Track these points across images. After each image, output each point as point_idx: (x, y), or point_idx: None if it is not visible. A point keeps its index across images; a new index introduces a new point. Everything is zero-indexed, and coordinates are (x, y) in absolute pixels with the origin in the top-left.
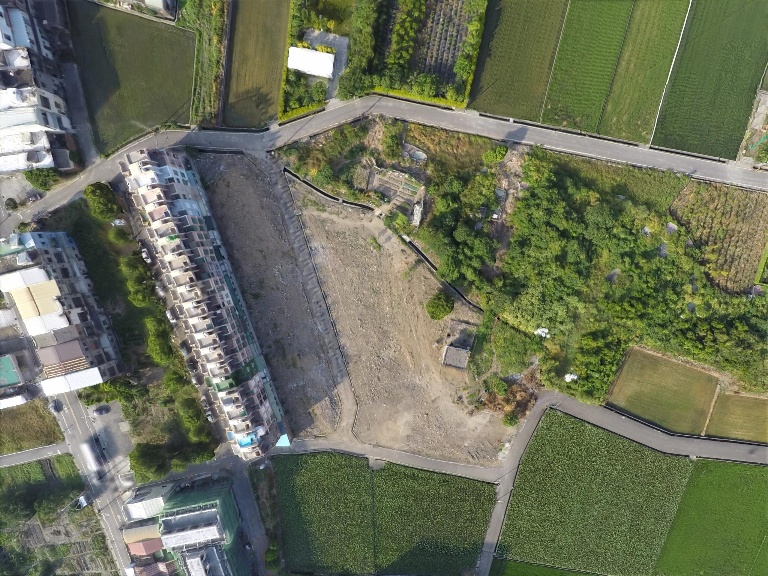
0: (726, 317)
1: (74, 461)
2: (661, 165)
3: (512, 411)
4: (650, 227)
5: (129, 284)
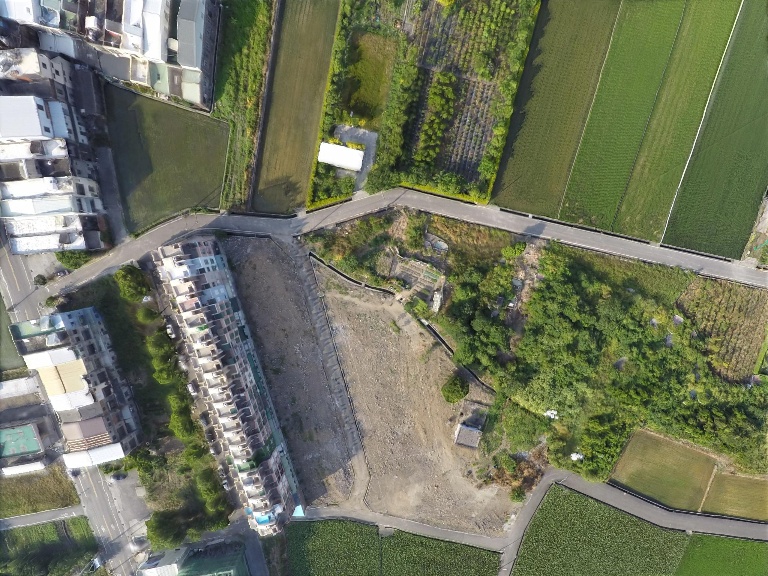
0: (726, 404)
1: (89, 523)
2: (670, 262)
3: (519, 486)
4: (658, 319)
5: (155, 363)
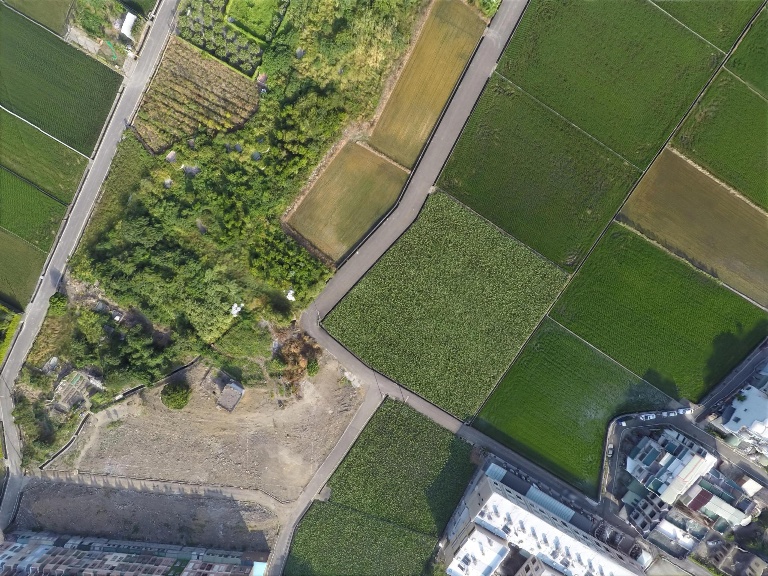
0: (278, 121)
1: None
2: (111, 152)
3: (307, 361)
4: (165, 178)
5: None
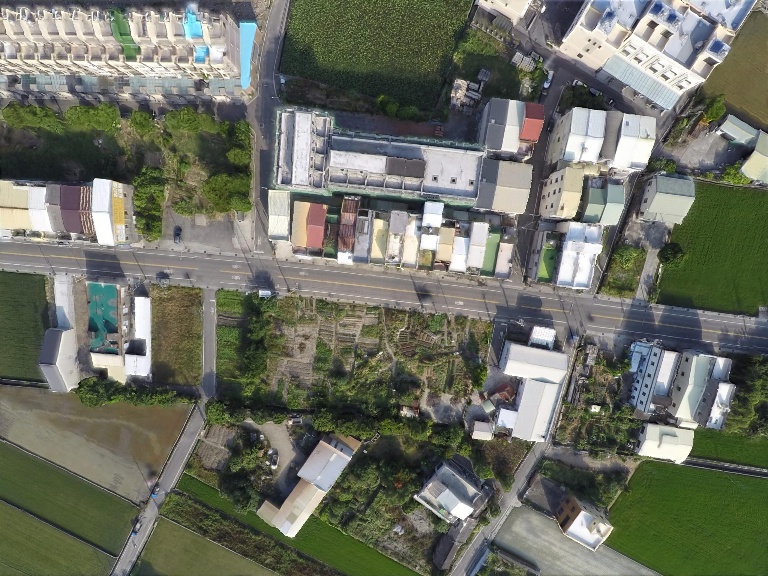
0: None
1: (226, 290)
2: None
3: None
4: None
5: (23, 115)
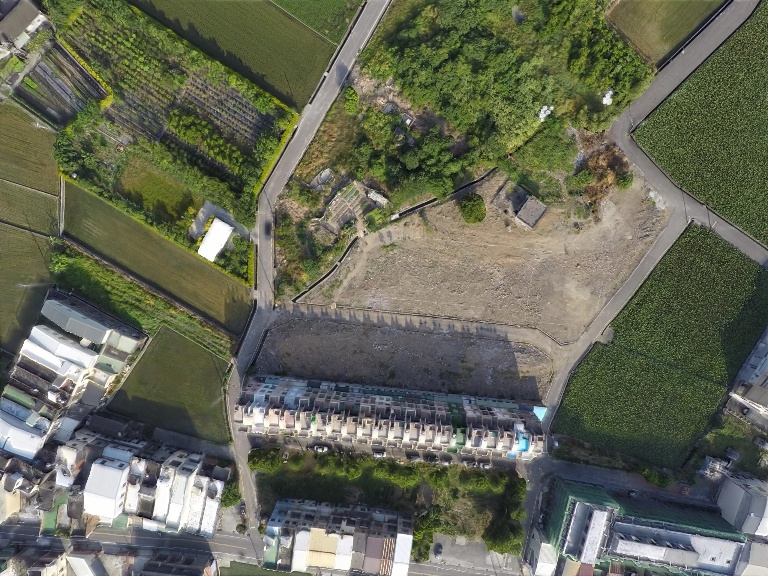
0: None
1: None
2: None
3: (616, 175)
4: None
5: (338, 473)
